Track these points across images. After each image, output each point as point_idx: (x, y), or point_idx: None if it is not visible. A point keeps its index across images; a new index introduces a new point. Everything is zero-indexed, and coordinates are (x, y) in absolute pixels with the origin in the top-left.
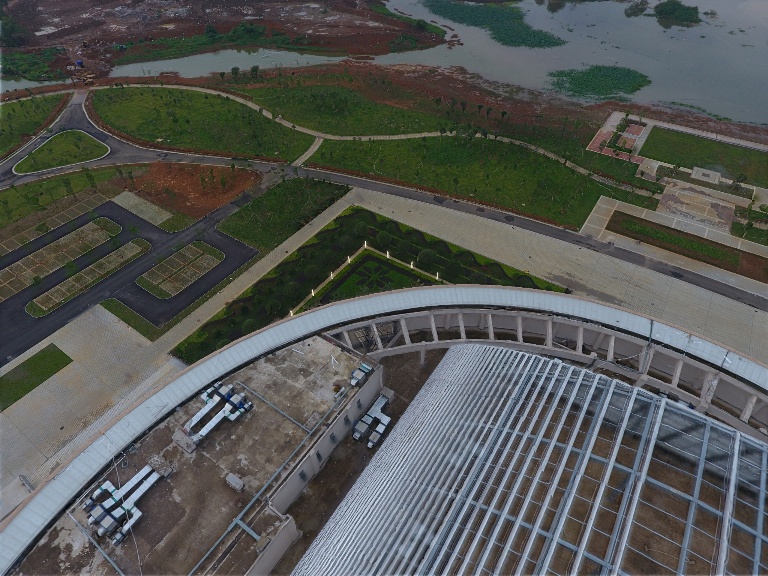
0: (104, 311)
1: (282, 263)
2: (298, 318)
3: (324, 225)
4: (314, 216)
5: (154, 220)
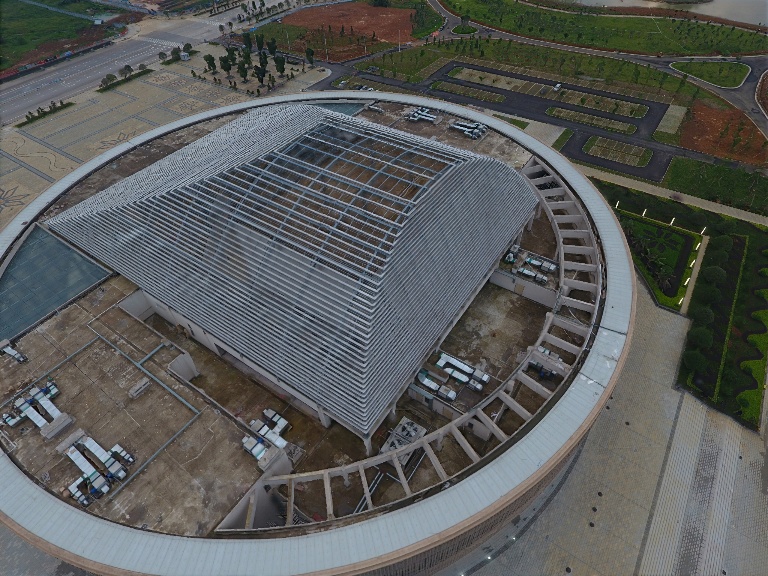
0: (561, 132)
1: (653, 195)
2: (543, 144)
3: (727, 214)
4: (737, 207)
5: (662, 127)
